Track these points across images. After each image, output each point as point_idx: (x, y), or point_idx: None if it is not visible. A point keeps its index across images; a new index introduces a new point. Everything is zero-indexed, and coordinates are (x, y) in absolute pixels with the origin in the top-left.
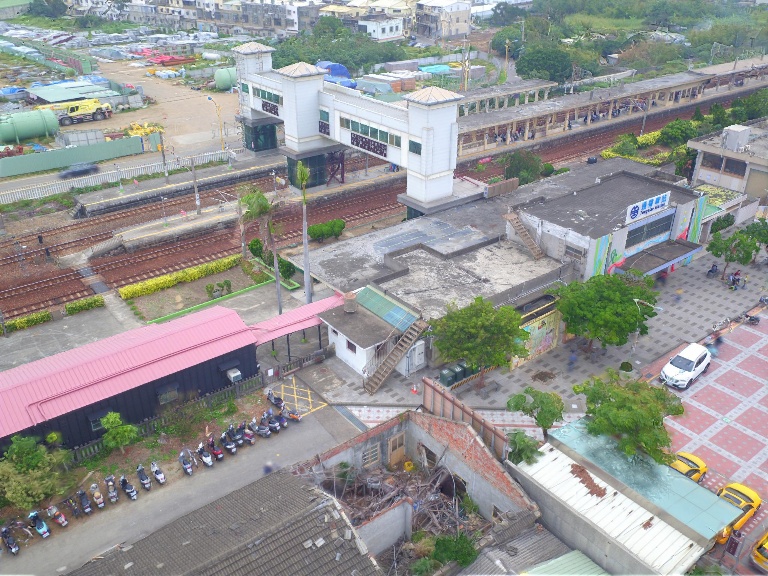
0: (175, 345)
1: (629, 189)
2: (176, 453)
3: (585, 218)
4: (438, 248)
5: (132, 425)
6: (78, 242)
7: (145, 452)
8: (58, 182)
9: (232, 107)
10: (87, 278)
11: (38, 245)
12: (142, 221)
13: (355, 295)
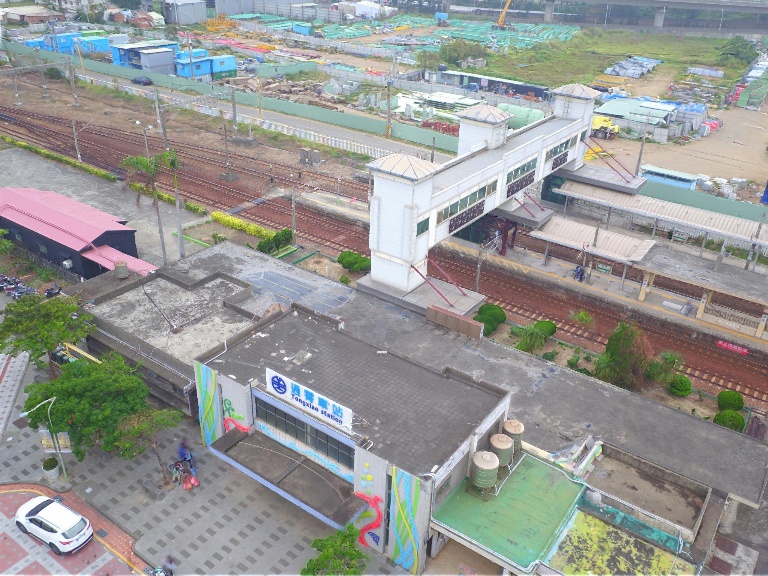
0: (65, 224)
1: (434, 402)
2: (7, 273)
3: (289, 360)
4: (268, 304)
5: (22, 248)
6: (310, 188)
7: (9, 263)
8: (391, 152)
9: (726, 173)
10: (248, 203)
11: (297, 178)
12: (360, 197)
13: (122, 265)
